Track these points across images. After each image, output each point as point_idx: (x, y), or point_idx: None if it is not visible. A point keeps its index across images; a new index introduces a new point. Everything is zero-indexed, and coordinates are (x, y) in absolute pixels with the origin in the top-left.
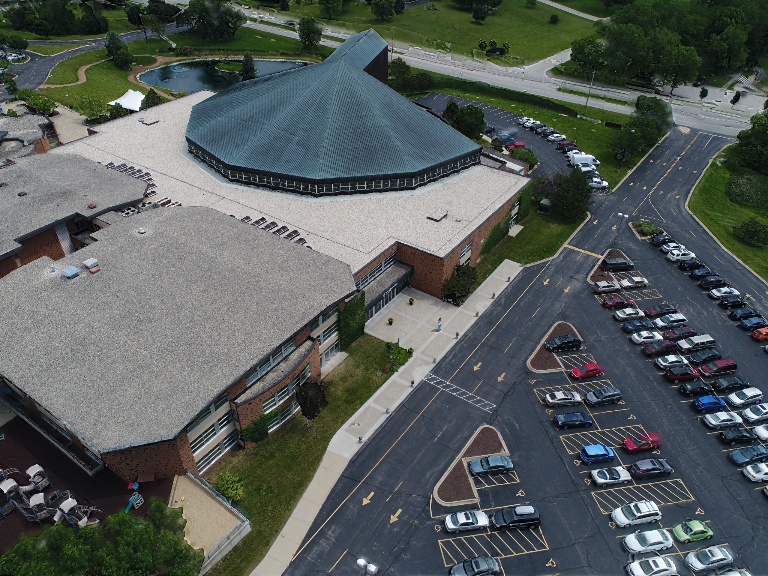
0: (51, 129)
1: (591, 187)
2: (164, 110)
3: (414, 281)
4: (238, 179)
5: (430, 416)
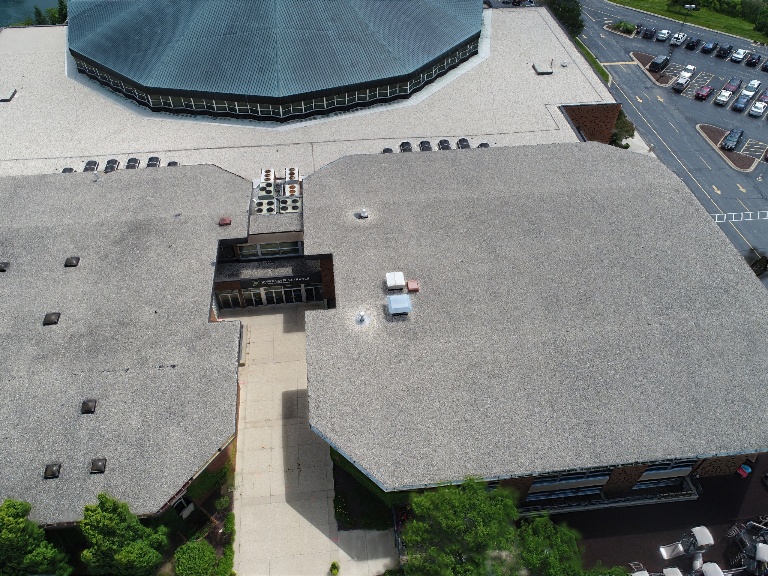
0: None
1: None
2: None
3: None
4: (293, 114)
5: (760, 246)
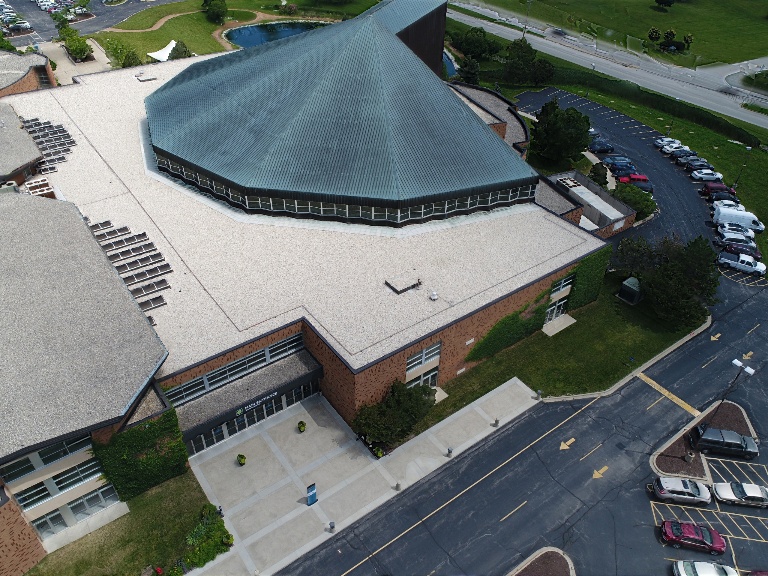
0: (45, 73)
1: (732, 268)
2: (176, 66)
3: (325, 388)
4: (167, 168)
5: None
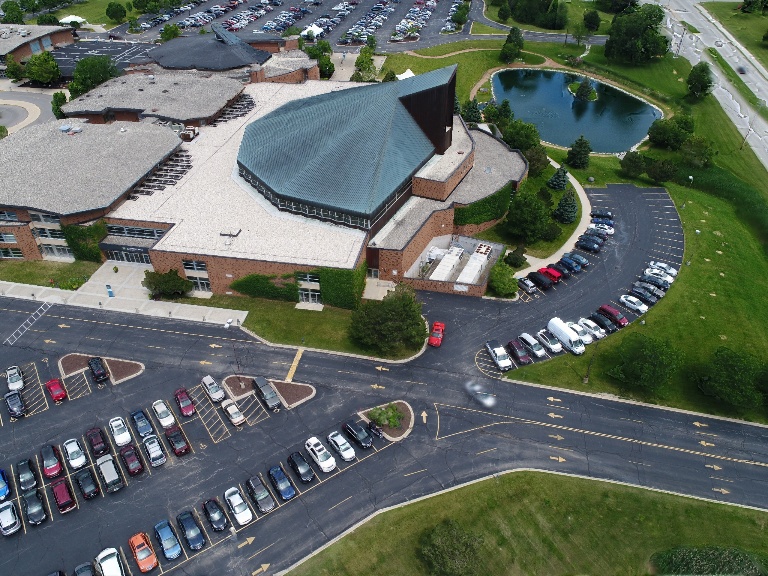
0: (307, 74)
1: None
2: None
3: None
4: None
5: (1, 314)
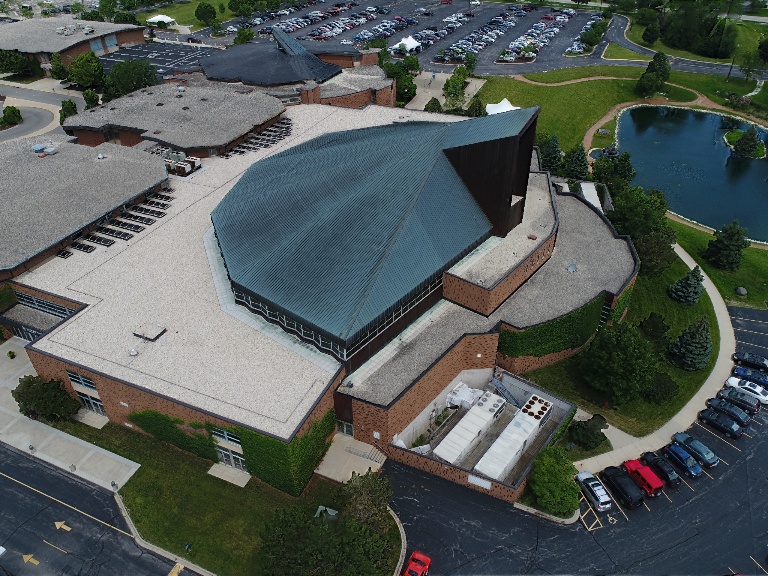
0: None
1: None
2: (438, 119)
3: None
4: None
5: None
